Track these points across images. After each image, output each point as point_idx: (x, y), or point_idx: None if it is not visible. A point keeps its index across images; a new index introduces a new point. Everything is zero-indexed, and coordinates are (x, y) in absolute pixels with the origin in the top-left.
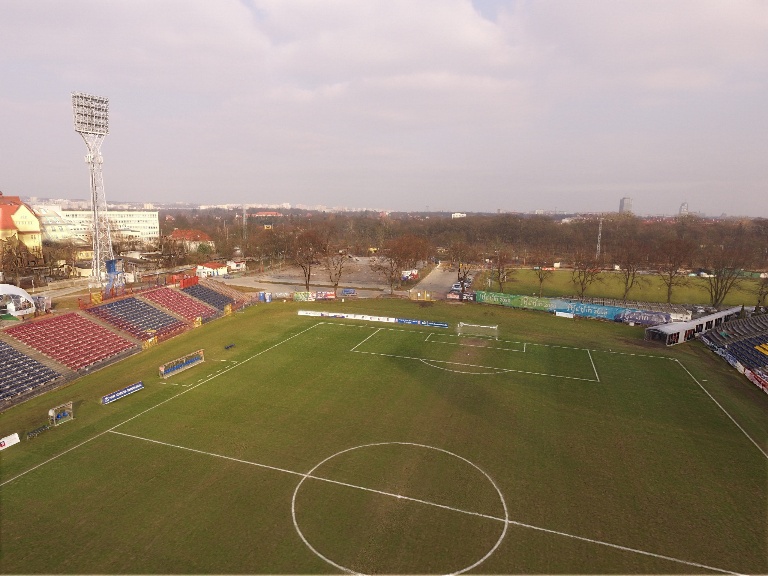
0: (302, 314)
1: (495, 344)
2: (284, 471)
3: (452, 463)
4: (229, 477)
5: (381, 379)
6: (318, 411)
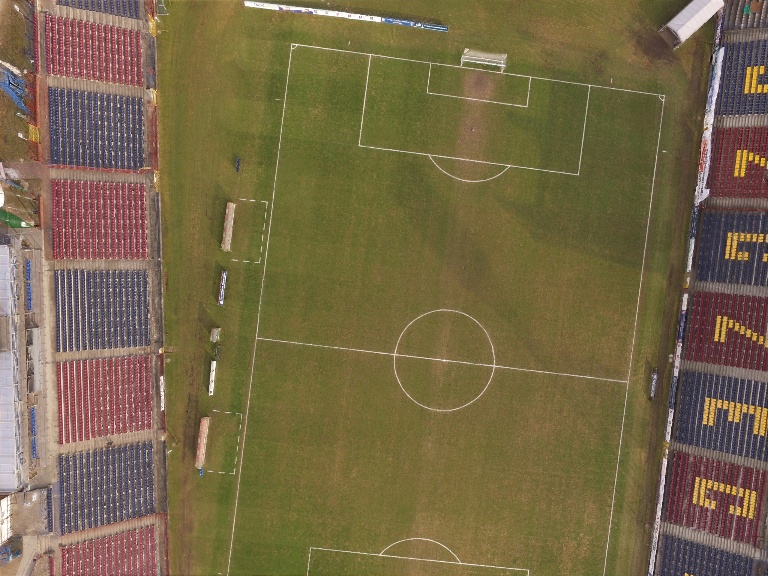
0: (251, 6)
1: (500, 90)
2: (382, 354)
3: (468, 326)
4: (357, 365)
5: (405, 214)
6: (375, 282)
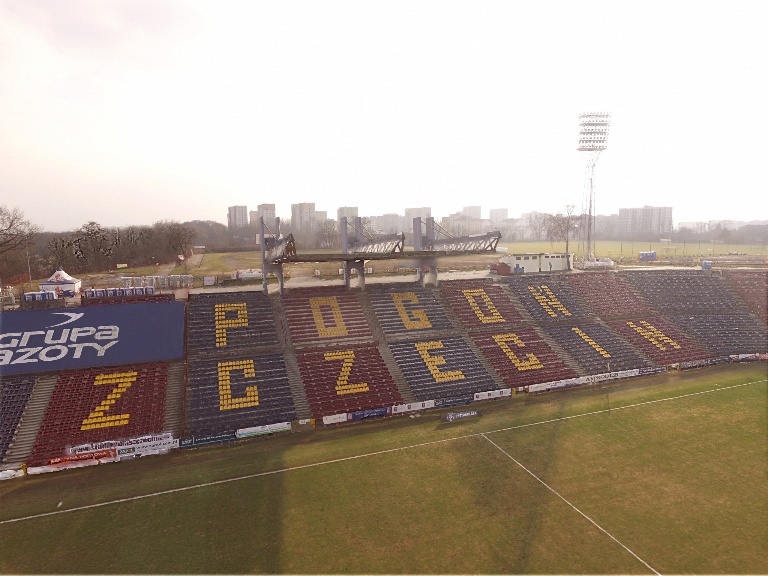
0: None
1: None
2: None
3: None
4: None
5: None
6: None
